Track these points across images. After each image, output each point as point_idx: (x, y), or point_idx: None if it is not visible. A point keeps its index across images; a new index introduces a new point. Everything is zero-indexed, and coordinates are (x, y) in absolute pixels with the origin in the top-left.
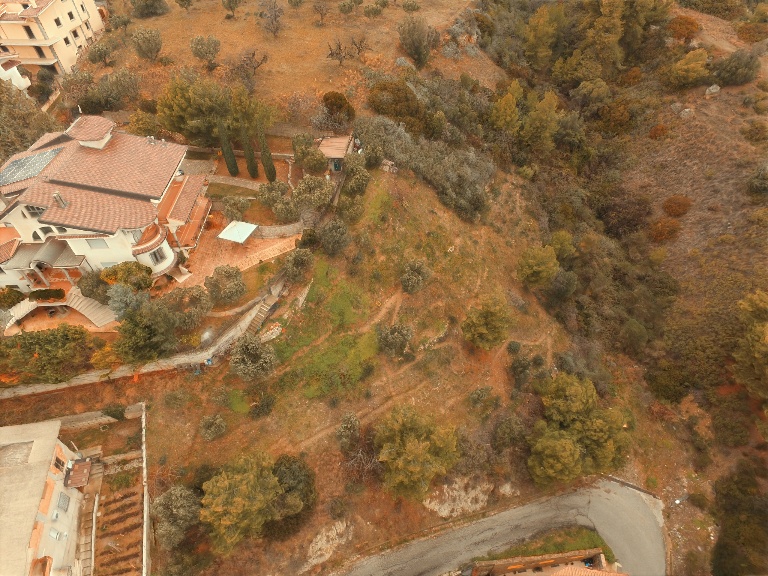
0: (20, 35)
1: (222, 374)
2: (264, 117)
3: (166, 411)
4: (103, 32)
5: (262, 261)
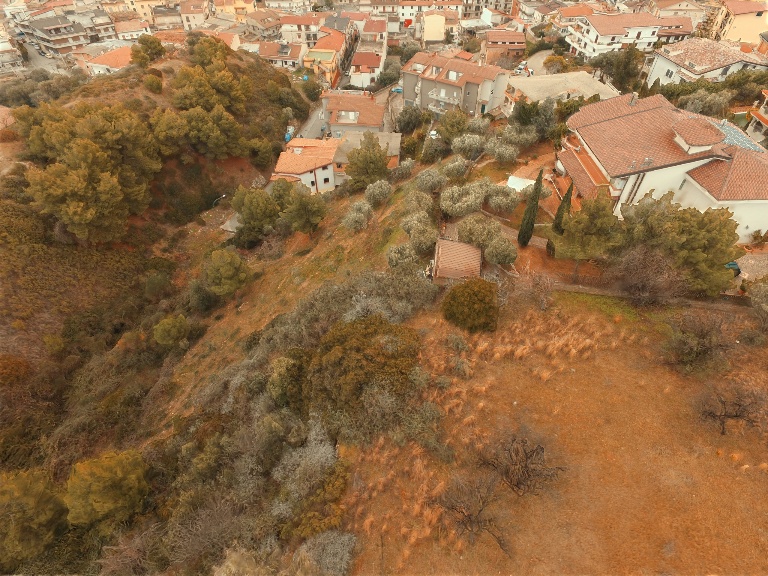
0: None
1: None
2: None
3: None
4: None
5: None
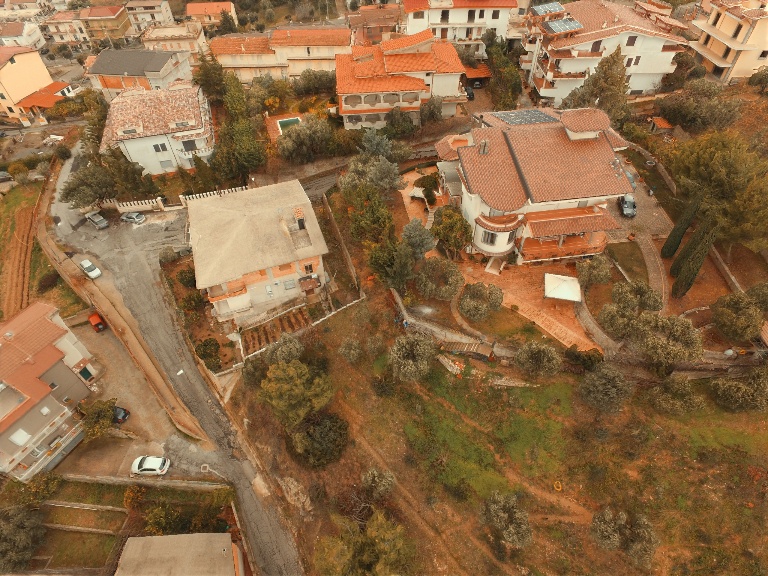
0: (729, 30)
1: None
2: (767, 236)
3: None
4: None
5: (534, 324)
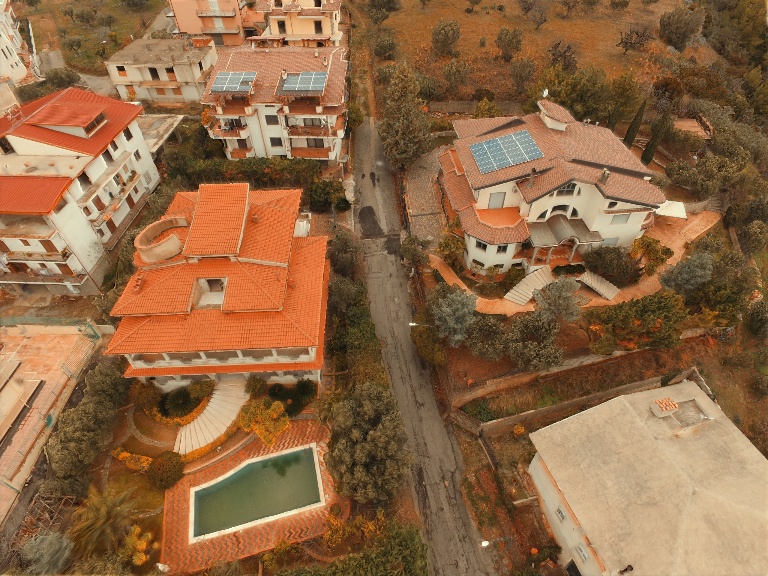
0: (307, 30)
1: (738, 339)
2: None
3: (719, 374)
4: (351, 27)
5: (708, 235)
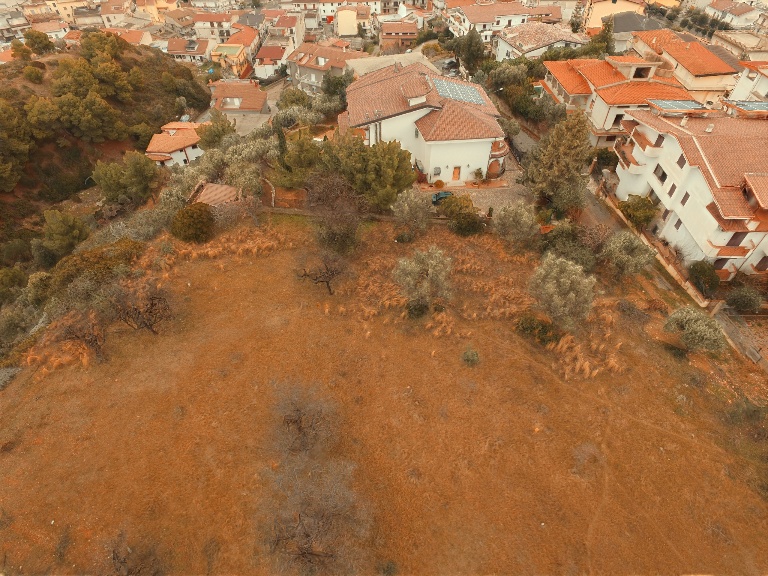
0: None
1: None
2: None
3: None
4: None
5: None
